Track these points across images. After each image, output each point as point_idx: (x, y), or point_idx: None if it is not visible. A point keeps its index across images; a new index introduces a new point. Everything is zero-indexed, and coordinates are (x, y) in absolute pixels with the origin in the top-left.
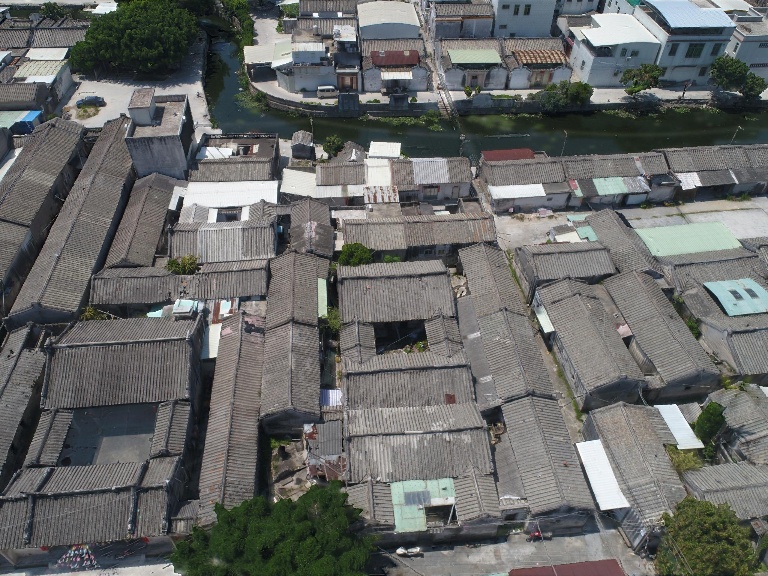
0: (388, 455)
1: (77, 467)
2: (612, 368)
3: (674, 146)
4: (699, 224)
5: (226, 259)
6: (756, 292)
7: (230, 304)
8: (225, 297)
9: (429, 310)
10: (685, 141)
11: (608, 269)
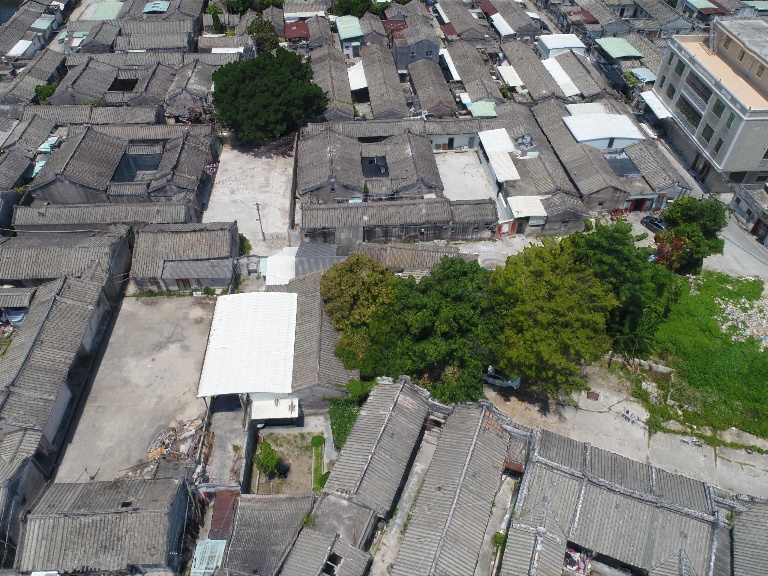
0: (198, 85)
1: (156, 173)
2: (181, 35)
3: (6, 15)
4: (99, 7)
5: (4, 139)
6: (157, 3)
7: (53, 137)
8: (46, 137)
9: (111, 73)
10: (5, 10)
11: (117, 28)
